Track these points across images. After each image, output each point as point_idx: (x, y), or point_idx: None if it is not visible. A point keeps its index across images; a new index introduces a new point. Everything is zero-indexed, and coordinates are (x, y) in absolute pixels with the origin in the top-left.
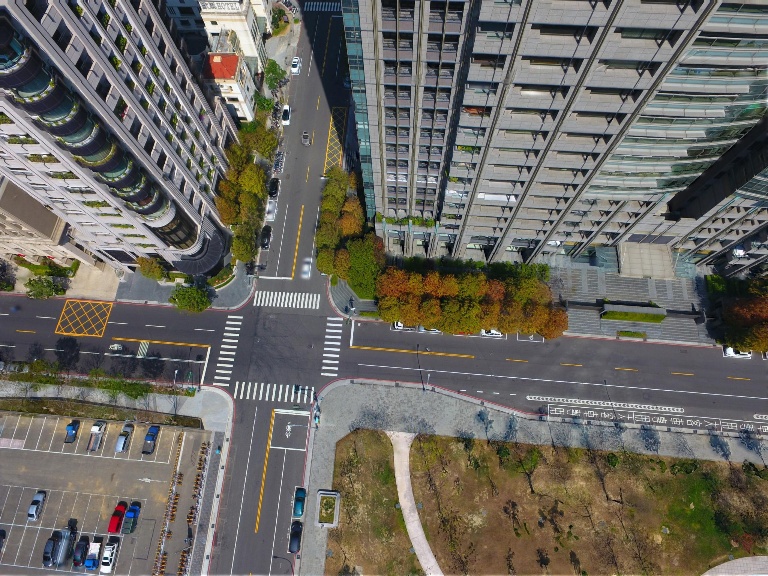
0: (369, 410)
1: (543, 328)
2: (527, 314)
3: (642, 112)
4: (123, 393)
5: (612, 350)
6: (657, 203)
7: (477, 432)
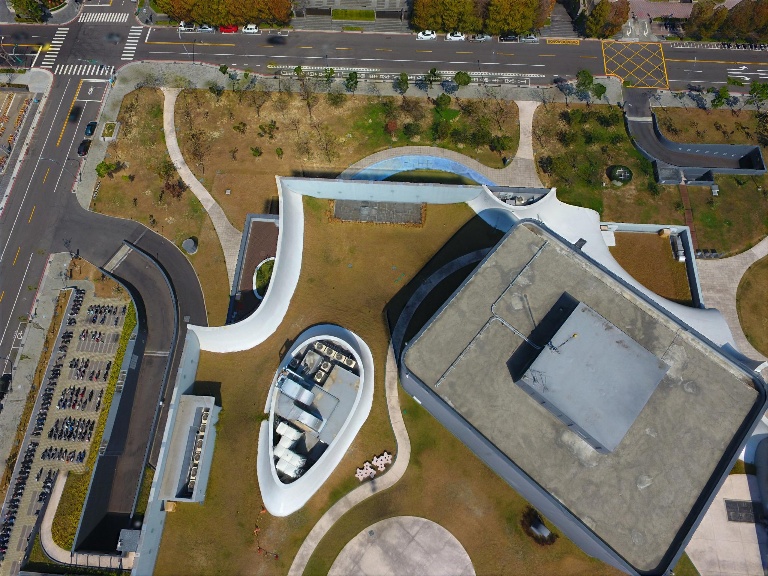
0: (151, 76)
1: (267, 1)
2: None
3: None
4: None
5: (336, 38)
6: None
7: (227, 86)
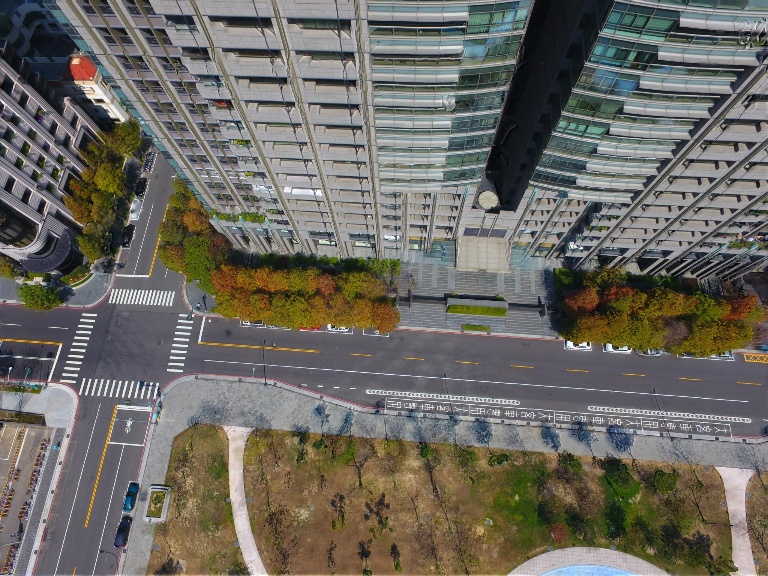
0: (209, 405)
1: (371, 322)
2: (352, 308)
3: (372, 103)
4: None
5: (455, 344)
6: (465, 196)
7: (313, 426)
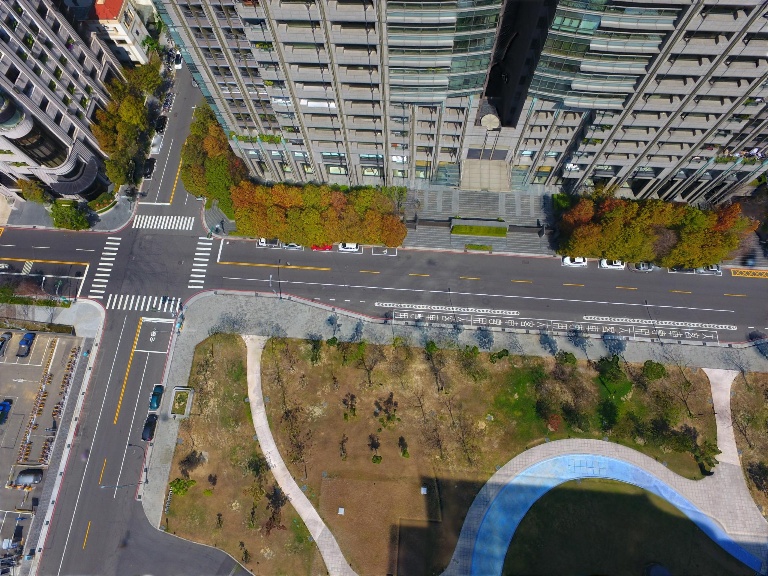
0: (228, 317)
1: (380, 234)
2: (362, 219)
3: None
4: (5, 306)
5: (459, 262)
6: (468, 109)
7: (325, 334)
